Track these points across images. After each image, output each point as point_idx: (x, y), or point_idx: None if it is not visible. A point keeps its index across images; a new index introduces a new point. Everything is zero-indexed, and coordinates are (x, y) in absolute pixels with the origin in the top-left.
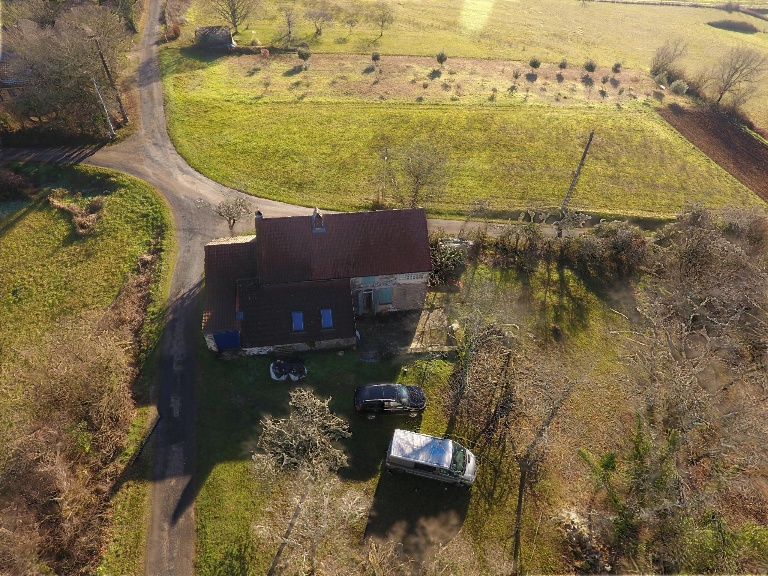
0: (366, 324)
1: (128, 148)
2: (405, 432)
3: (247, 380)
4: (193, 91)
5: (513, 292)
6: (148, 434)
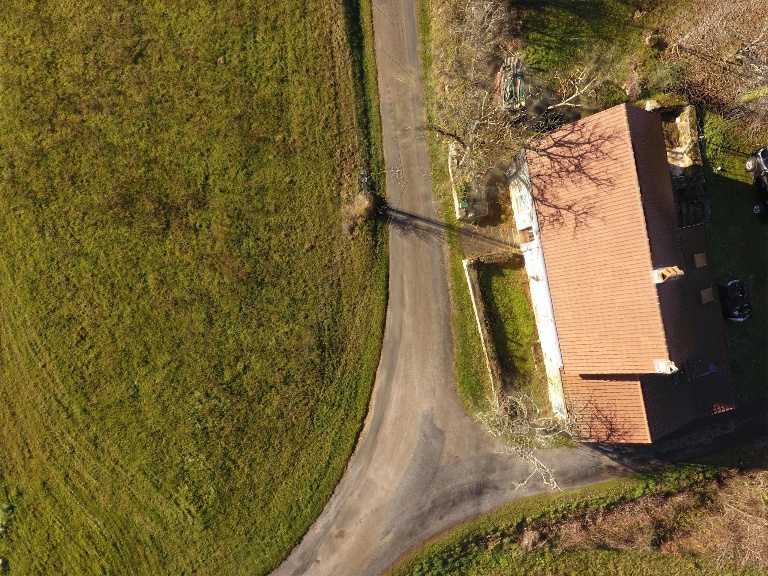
0: None
1: None
2: None
3: (748, 345)
4: None
5: (568, 21)
6: None
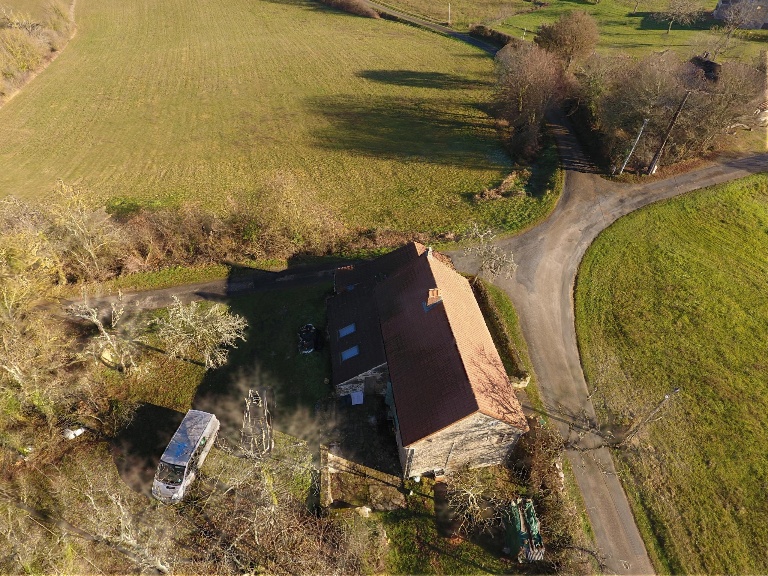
0: (376, 411)
1: (603, 187)
2: (208, 422)
3: (302, 314)
4: (763, 202)
5: None
6: (264, 269)
